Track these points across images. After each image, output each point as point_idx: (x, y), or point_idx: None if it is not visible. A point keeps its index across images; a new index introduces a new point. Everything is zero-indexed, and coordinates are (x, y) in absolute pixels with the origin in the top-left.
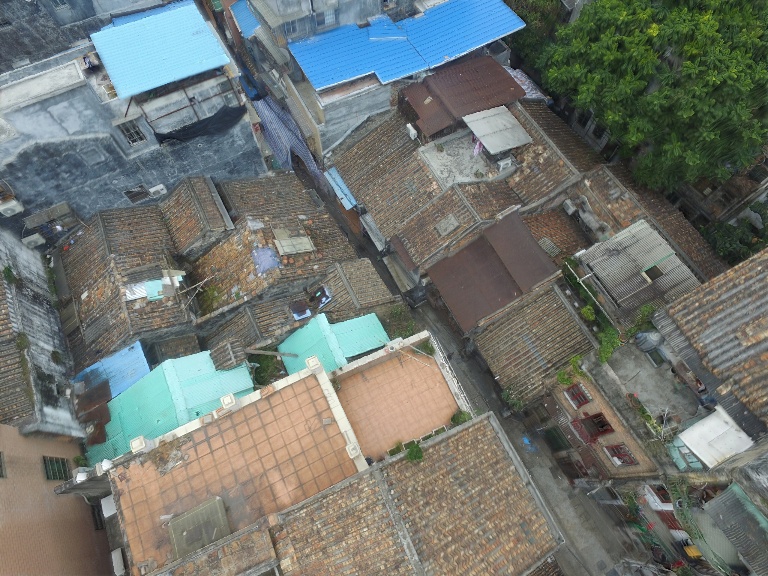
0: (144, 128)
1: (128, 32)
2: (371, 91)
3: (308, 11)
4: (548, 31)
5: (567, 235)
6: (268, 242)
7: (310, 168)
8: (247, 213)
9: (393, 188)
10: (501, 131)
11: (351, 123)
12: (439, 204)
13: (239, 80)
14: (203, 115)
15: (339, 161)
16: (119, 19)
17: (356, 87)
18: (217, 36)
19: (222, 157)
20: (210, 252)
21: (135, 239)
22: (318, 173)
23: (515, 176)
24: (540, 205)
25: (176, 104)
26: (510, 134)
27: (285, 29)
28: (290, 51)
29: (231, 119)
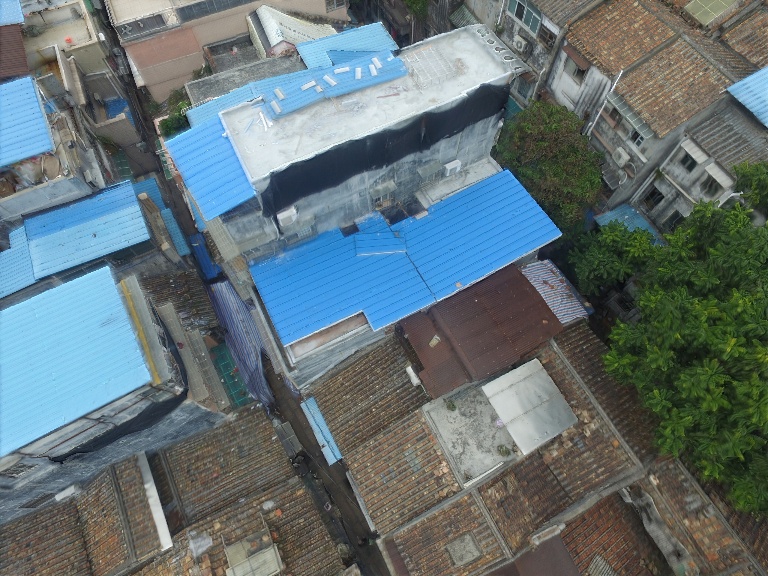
0: (31, 460)
1: (8, 325)
2: (359, 334)
3: (274, 234)
4: (585, 214)
5: (624, 538)
6: (217, 574)
7: (285, 381)
8: (189, 526)
9: (389, 458)
10: (535, 408)
11: (334, 359)
12: (452, 512)
13: (200, 250)
14: (122, 419)
15: (320, 392)
16: (33, 221)
17: (339, 329)
18: (143, 303)
19: (158, 434)
20: (140, 572)
21: (33, 572)
22: (295, 392)
23: (551, 448)
24: (589, 507)
25: (76, 430)
26: (547, 413)
27: (244, 255)
28: (252, 278)
29: (164, 411)
